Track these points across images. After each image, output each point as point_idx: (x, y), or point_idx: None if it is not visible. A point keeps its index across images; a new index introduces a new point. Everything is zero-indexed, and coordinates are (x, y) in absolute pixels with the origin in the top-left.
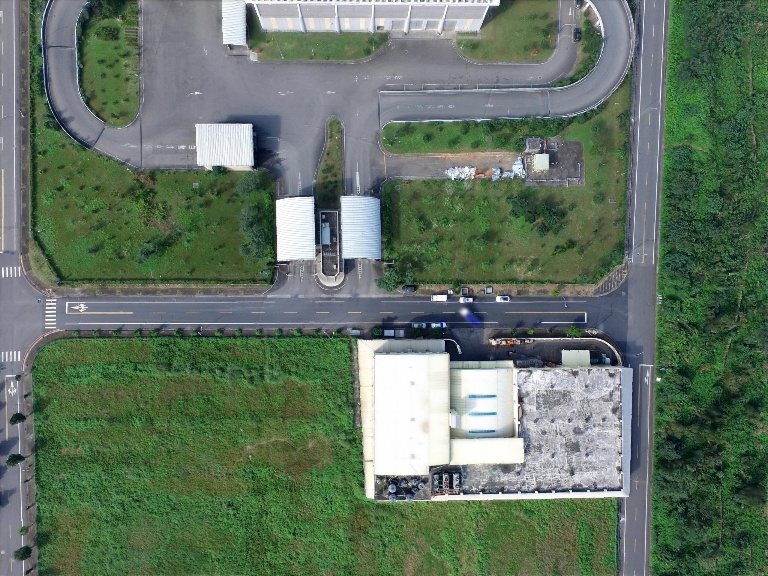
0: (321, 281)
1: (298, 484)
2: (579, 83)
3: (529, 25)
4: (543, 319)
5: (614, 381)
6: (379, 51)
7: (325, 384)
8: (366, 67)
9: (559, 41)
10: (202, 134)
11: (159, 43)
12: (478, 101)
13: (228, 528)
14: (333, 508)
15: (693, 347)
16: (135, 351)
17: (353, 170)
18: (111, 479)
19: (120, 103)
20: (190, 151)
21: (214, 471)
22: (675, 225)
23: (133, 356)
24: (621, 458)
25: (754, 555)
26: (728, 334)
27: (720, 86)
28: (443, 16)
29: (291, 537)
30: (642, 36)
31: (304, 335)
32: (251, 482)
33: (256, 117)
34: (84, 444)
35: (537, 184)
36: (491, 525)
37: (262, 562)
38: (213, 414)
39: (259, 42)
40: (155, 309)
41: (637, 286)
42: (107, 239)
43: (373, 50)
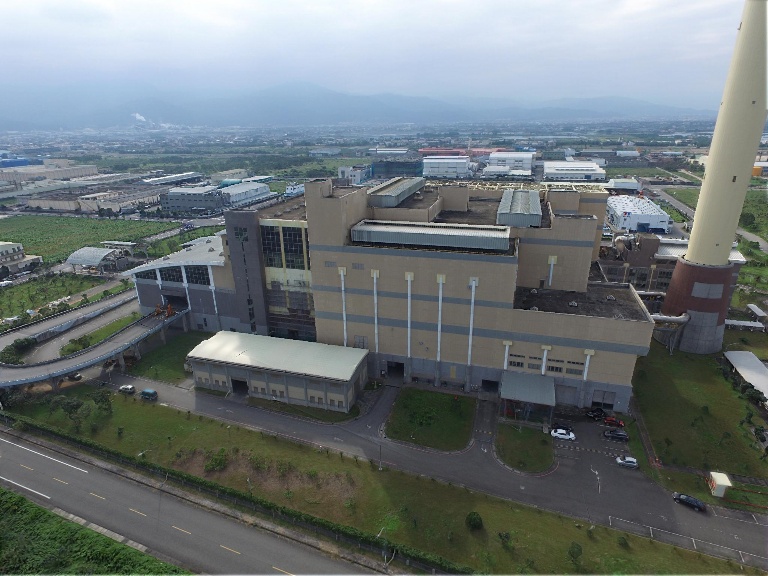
0: None
1: None
2: None
3: None
4: None
5: None
6: None
7: None
8: None
9: None
10: None
11: None
12: None
13: None
14: None
15: None
16: None
17: None
18: None
19: None
20: None
21: None
22: None
23: None
24: None
25: None
26: None
27: None
28: None
29: None
30: None
31: None
32: None
33: None
34: None
35: None
36: None
37: None
38: None
39: None
40: None
41: None
42: None
43: None
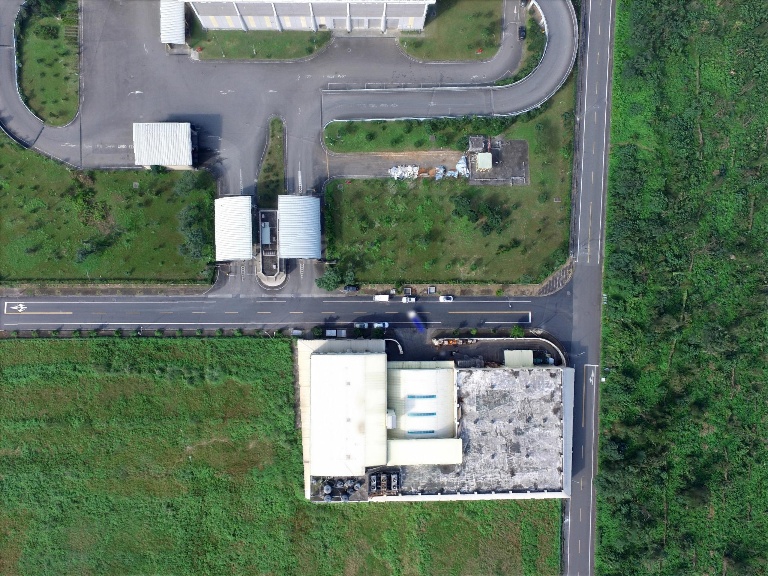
0: (262, 281)
1: (238, 485)
2: (523, 81)
3: (473, 23)
4: (487, 319)
5: (555, 381)
6: (322, 50)
7: (266, 384)
8: (308, 66)
9: (504, 39)
10: (139, 133)
11: (99, 42)
12: (421, 100)
13: (167, 529)
14: (273, 509)
15: (637, 347)
16: (74, 351)
17: (295, 169)
18: (49, 480)
19: (60, 102)
20: (130, 150)
21: (153, 472)
22: (619, 224)
23: (72, 356)
24: (562, 459)
25: (699, 556)
26: (672, 334)
27: (667, 84)
28: (383, 14)
29: (231, 538)
30: (588, 34)
31: (245, 335)
32: (191, 483)
33: (197, 116)
34: (22, 445)
35: (481, 183)
36: (433, 526)
37: (202, 563)
38: (153, 415)
39: (200, 41)
40: (95, 309)
41: (582, 286)
42: (46, 239)
43: (315, 49)
